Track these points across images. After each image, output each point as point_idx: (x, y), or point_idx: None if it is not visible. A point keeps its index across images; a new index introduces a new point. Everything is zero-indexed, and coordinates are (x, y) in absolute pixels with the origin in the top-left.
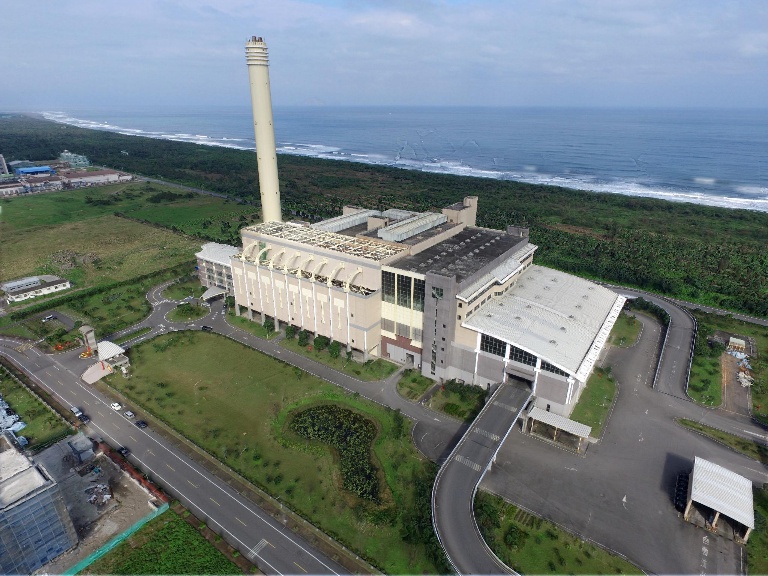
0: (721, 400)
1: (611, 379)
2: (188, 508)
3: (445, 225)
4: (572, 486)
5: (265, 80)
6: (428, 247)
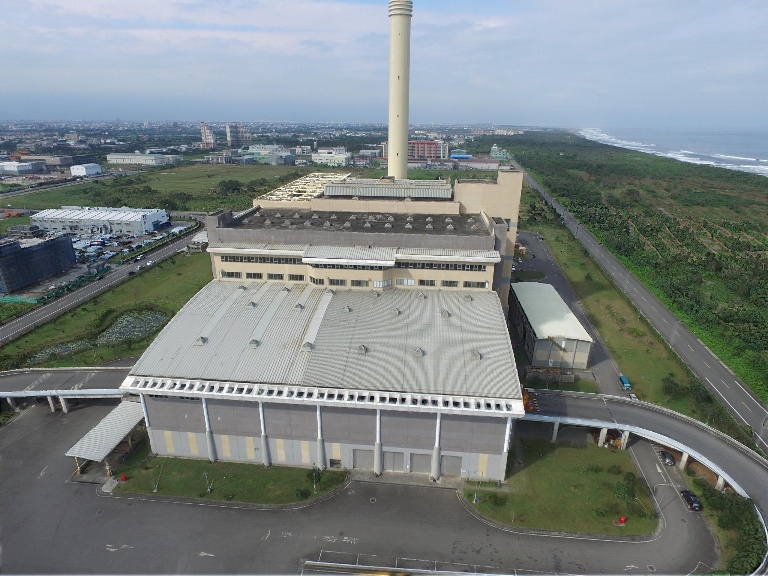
0: None
1: None
2: None
3: (440, 201)
4: (6, 476)
5: (399, 31)
6: (350, 211)
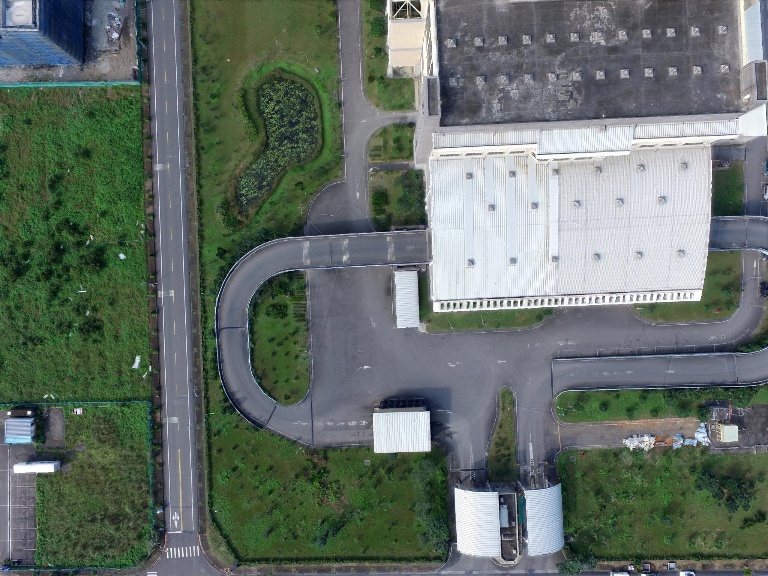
0: (576, 422)
1: (536, 319)
2: (150, 96)
3: None
4: (354, 329)
5: None
6: None
